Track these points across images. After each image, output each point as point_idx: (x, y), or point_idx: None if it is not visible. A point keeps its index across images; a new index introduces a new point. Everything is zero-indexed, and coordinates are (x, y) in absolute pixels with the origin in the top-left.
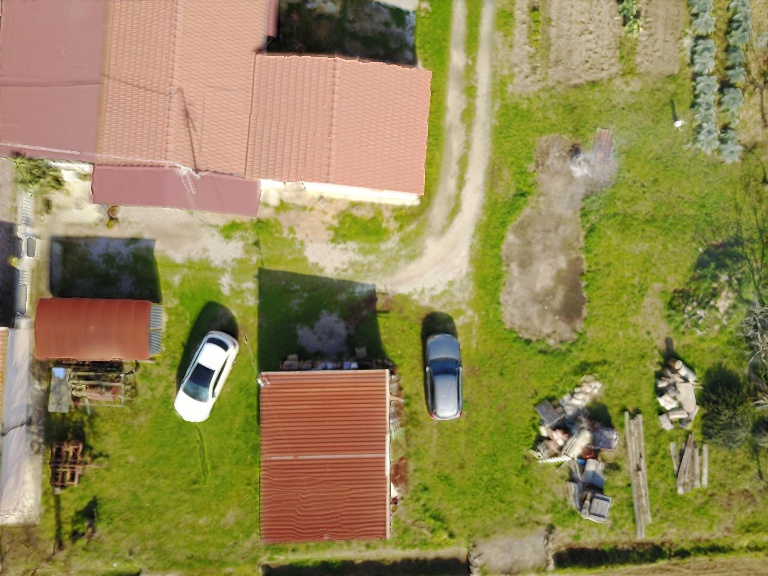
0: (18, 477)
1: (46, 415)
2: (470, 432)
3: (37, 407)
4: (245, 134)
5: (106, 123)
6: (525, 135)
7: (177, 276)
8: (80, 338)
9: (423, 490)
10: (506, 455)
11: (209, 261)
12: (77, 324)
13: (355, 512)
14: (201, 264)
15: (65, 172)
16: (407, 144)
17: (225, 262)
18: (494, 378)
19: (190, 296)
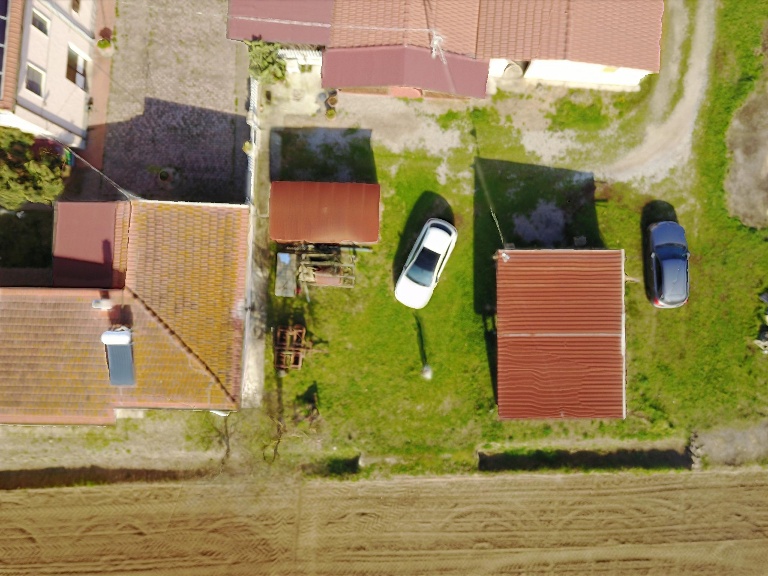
0: (245, 359)
1: (268, 301)
2: (691, 322)
3: (260, 293)
4: (475, 14)
5: (337, 6)
6: (751, 17)
7: (393, 166)
8: (313, 219)
9: (643, 380)
10: (729, 346)
11: (425, 150)
12: (310, 205)
13: (593, 390)
14: (417, 153)
15: (288, 61)
16: (643, 21)
17: (441, 151)
18: (717, 268)
19: (406, 185)
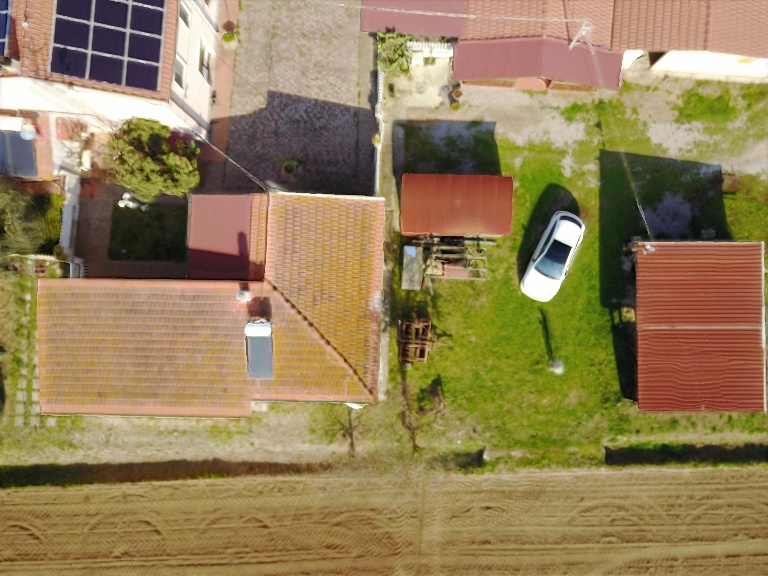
0: None
1: (392, 294)
2: None
3: (383, 286)
4: (611, 5)
5: None
6: None
7: (517, 158)
8: (445, 212)
9: None
10: None
11: (549, 143)
12: (442, 198)
13: (735, 383)
14: (541, 146)
15: (414, 53)
16: None
17: (566, 144)
18: None
19: (530, 178)
